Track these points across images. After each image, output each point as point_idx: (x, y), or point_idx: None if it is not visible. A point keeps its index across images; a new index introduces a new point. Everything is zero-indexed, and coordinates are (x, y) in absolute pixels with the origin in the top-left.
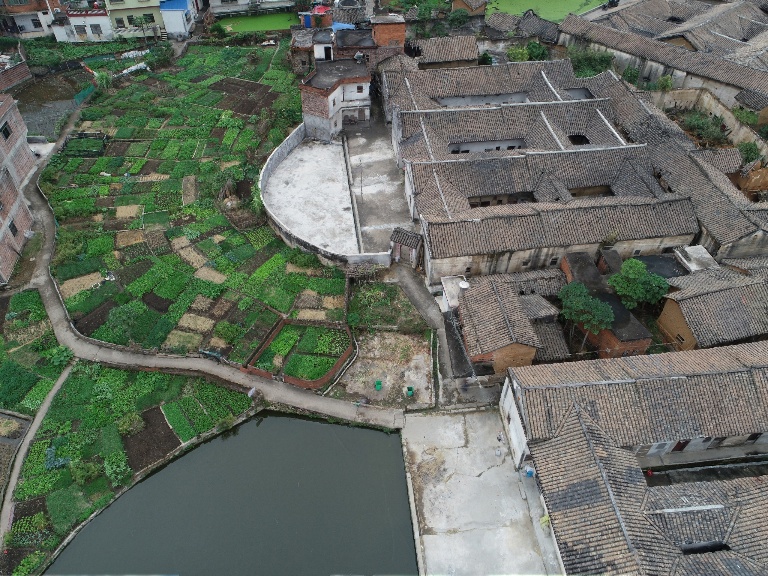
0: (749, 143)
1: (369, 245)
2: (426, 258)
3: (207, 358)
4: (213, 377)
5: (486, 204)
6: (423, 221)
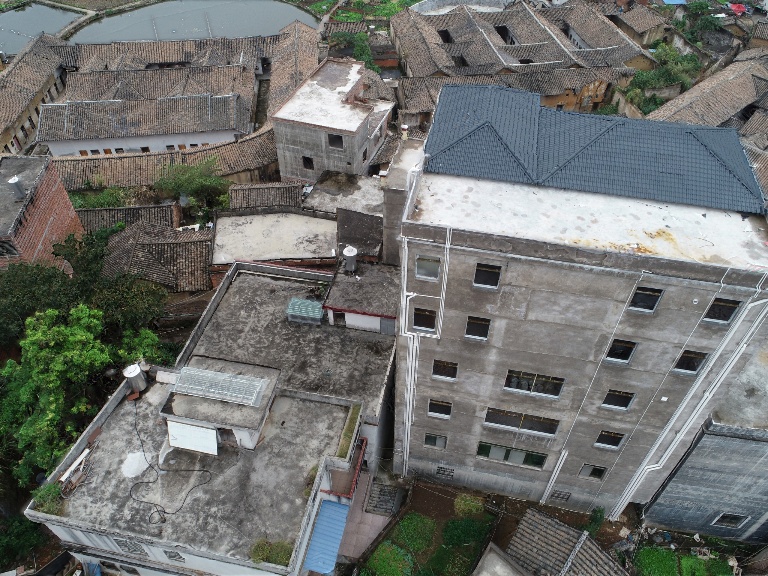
0: None
1: None
2: None
3: (346, 3)
4: (335, 4)
5: None
6: (413, 10)
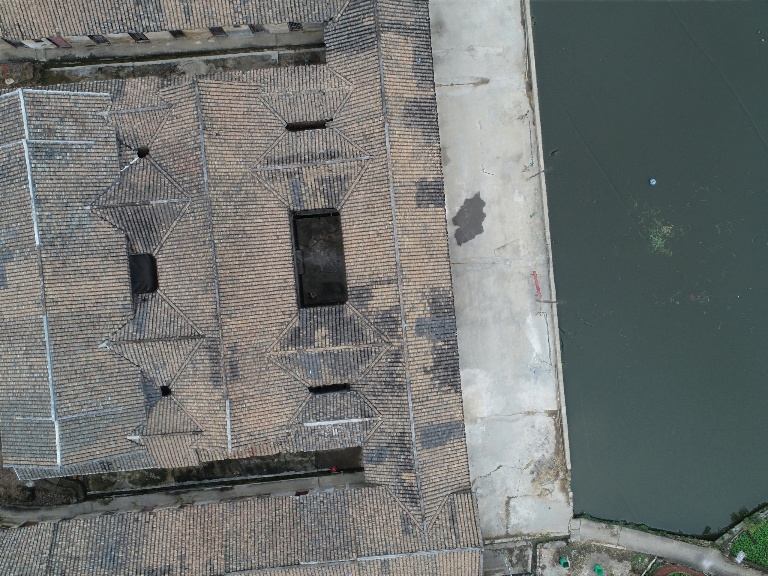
0: None
1: None
2: None
3: None
4: None
5: None
6: None
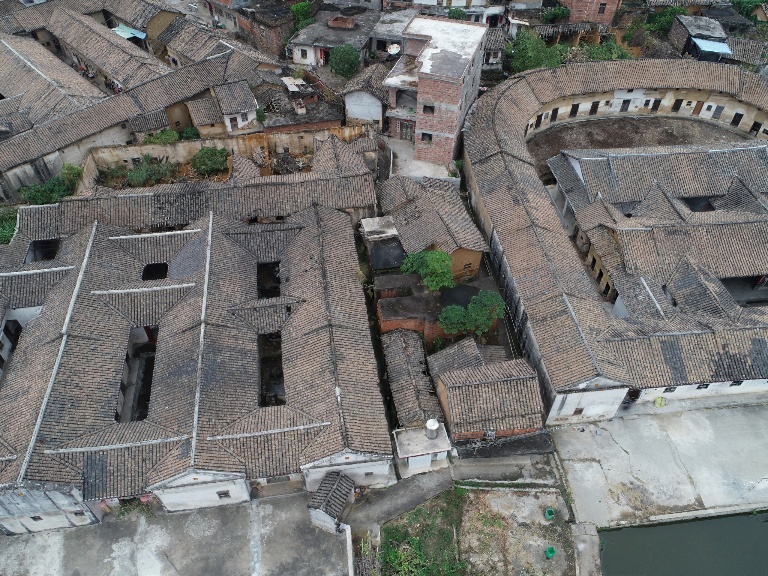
0: (206, 149)
1: (299, 570)
2: (359, 475)
3: None
4: None
5: None
6: None
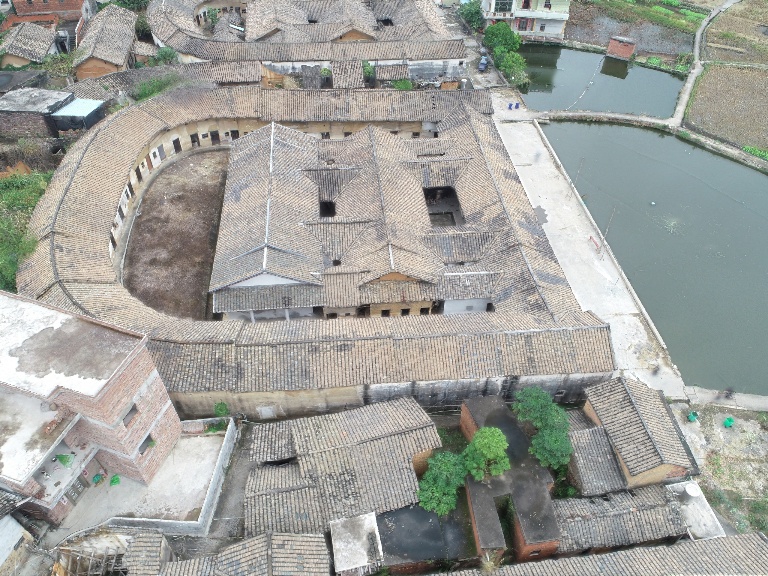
0: None
1: None
2: None
3: None
4: None
5: None
6: None
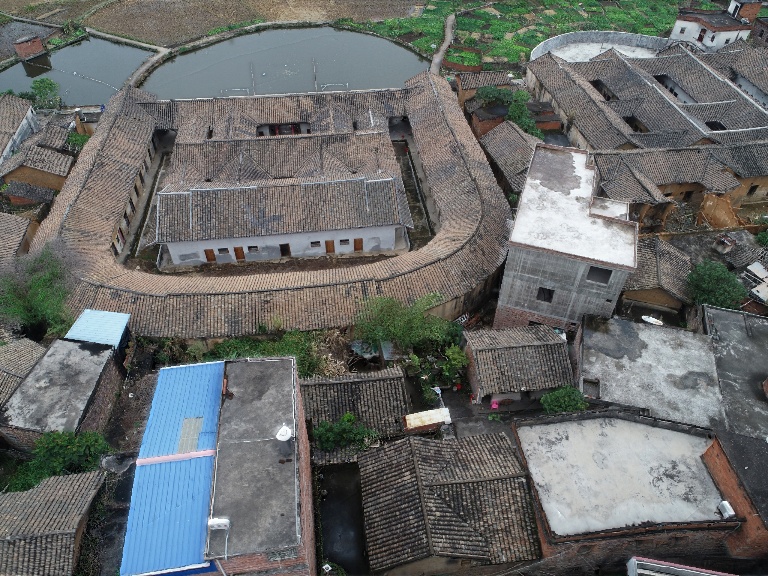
0: None
1: None
2: None
3: None
4: None
5: (609, 99)
6: None
